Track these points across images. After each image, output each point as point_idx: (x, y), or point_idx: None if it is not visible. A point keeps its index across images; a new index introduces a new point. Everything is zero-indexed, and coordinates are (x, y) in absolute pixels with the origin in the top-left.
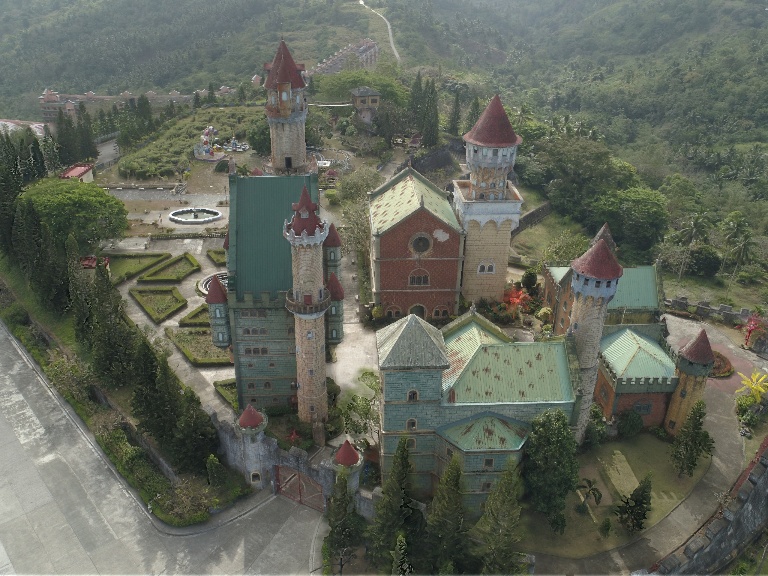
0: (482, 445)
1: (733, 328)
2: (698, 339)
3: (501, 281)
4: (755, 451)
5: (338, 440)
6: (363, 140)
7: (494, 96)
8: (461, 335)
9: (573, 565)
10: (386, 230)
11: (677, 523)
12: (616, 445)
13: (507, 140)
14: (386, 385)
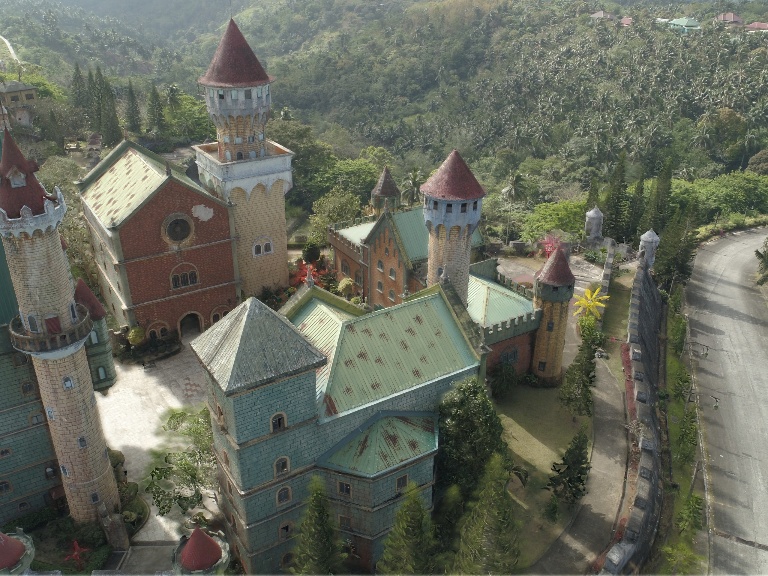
0: (390, 461)
1: (526, 257)
2: (556, 259)
3: (283, 261)
4: (621, 369)
5: (147, 530)
6: (27, 146)
7: None
8: (304, 320)
9: (533, 574)
10: (125, 218)
11: (603, 474)
12: (496, 409)
13: (258, 77)
14: (236, 419)
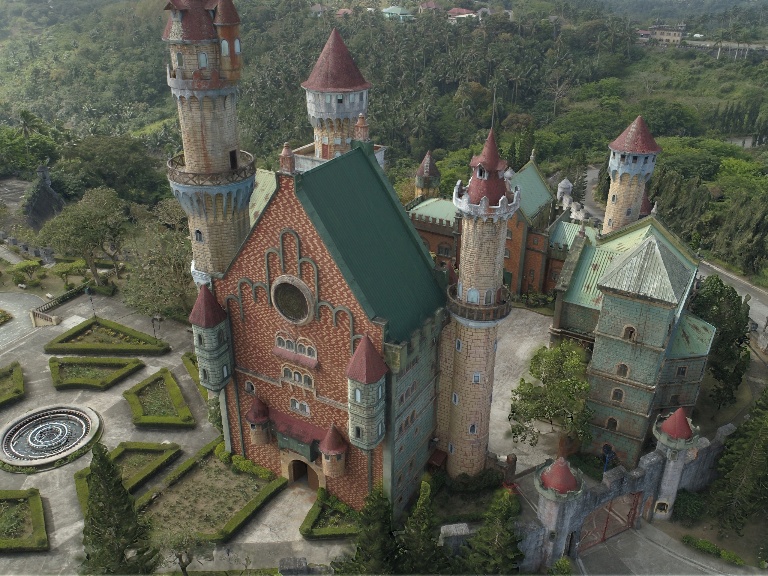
0: (706, 342)
1: None
2: (643, 195)
3: None
4: None
5: None
6: None
7: (334, 31)
8: (592, 262)
9: None
10: None
11: None
12: None
13: None
14: None
